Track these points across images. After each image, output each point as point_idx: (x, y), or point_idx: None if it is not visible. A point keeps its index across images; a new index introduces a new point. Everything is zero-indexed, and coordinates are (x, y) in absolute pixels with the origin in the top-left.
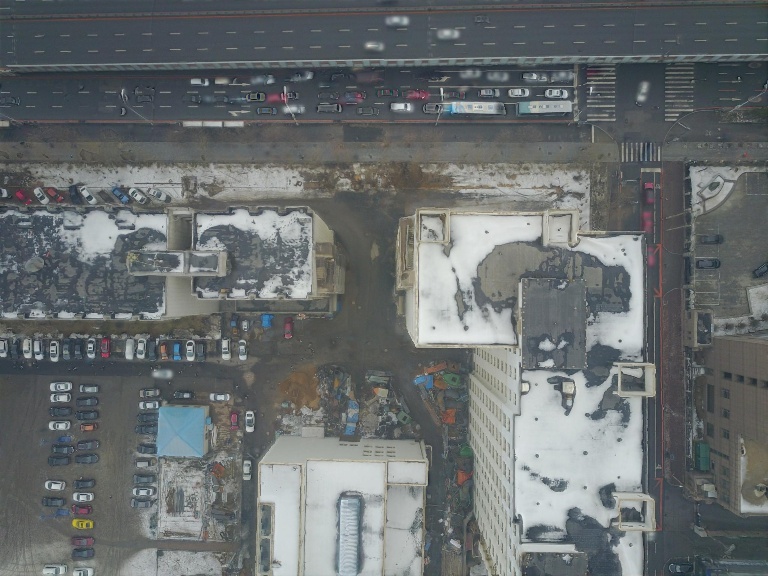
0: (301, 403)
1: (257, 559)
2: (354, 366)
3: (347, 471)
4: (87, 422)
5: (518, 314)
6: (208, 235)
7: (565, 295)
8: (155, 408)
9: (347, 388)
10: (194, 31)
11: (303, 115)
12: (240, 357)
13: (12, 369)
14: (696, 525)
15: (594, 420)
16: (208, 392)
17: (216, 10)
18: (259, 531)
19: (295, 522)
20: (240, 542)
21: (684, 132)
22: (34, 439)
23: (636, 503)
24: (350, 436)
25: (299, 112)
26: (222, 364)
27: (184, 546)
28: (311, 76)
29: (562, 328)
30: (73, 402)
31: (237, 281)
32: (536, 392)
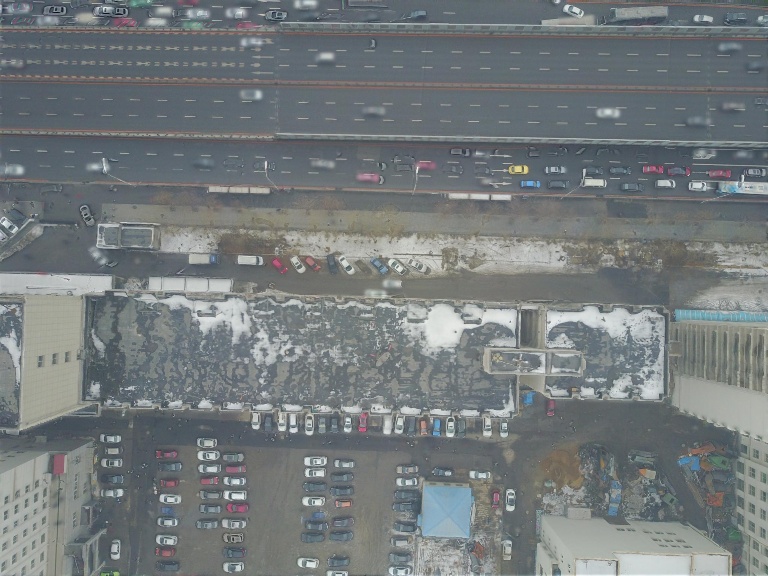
0: (563, 482)
1: None
2: (616, 445)
3: (652, 564)
4: (342, 498)
5: None
6: (557, 332)
7: None
8: (413, 485)
9: (610, 468)
10: (466, 103)
11: (567, 189)
12: (501, 434)
13: (264, 442)
14: None
15: None
16: (467, 469)
17: (489, 83)
18: None
19: None
20: None
21: None
22: (286, 514)
23: None
24: (613, 517)
25: (564, 186)
26: (481, 440)
27: None
28: (581, 151)
29: None
30: (327, 477)
31: (586, 379)
32: None
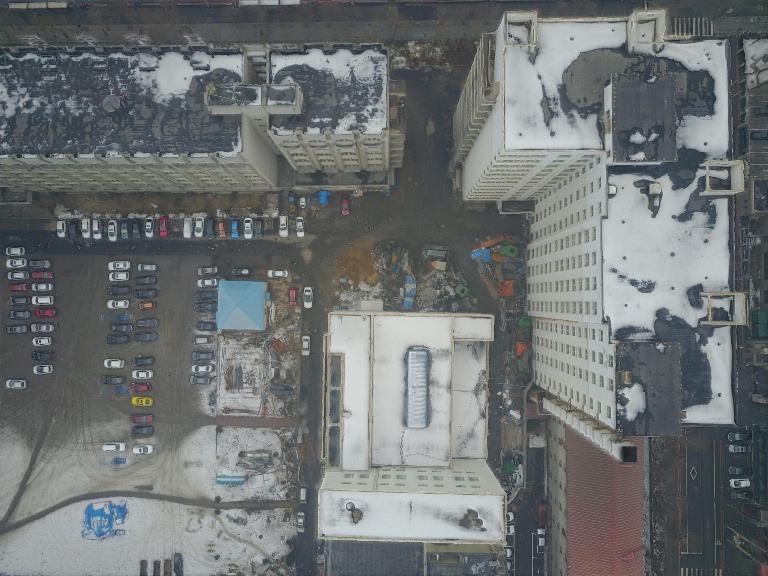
0: (359, 279)
1: (327, 409)
2: (411, 242)
3: (414, 326)
4: (145, 301)
5: (604, 119)
6: (282, 75)
7: (655, 89)
8: (213, 285)
9: (404, 263)
10: None
11: None
12: (298, 234)
13: (70, 249)
14: (754, 393)
15: (681, 222)
16: (266, 269)
17: None
18: (329, 382)
19: (365, 372)
20: (299, 418)
21: (739, 0)
22: (92, 318)
23: (724, 302)
24: (408, 310)
25: None
26: (279, 242)
27: (243, 422)
28: None
29: (652, 121)
30: (131, 281)
31: (312, 120)
32: (623, 195)
